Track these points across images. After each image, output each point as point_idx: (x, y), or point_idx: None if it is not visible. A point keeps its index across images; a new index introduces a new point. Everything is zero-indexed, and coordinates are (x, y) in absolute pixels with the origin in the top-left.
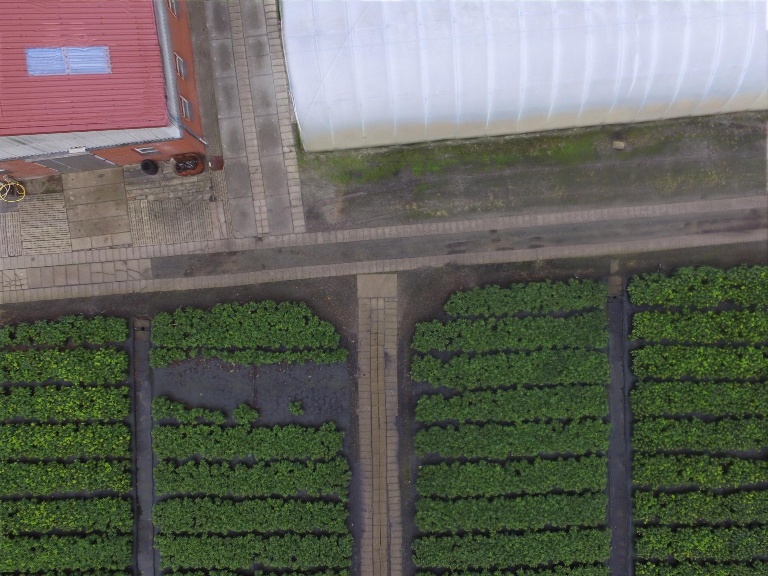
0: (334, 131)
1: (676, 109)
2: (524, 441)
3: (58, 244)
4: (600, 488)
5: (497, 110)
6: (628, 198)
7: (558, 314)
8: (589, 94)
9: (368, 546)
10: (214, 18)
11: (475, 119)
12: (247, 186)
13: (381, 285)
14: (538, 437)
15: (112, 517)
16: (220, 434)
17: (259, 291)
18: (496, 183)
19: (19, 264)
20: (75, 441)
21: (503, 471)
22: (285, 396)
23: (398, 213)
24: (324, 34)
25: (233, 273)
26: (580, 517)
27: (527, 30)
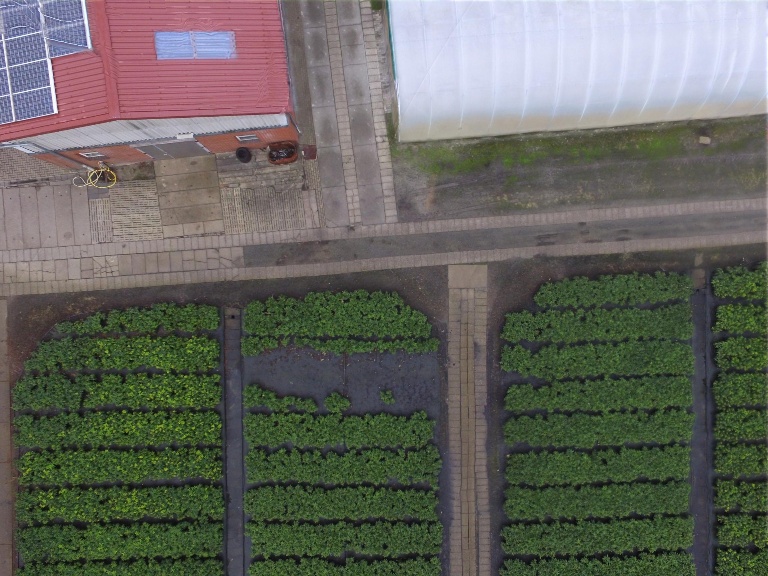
0: (432, 121)
1: (764, 105)
2: (611, 430)
3: (149, 231)
4: (683, 477)
5: (594, 103)
6: (714, 192)
7: (644, 306)
8: (684, 89)
9: (457, 533)
10: (309, 6)
11: (570, 112)
12: (340, 175)
13: (472, 276)
14: (624, 427)
15: (204, 505)
16: (312, 422)
17: (351, 280)
18: (586, 176)
19: (110, 251)
20: (167, 429)
21: (590, 460)
22: (375, 385)
23: (489, 204)
24: (432, 24)
25: (325, 262)
26: (664, 505)
27: (631, 24)
